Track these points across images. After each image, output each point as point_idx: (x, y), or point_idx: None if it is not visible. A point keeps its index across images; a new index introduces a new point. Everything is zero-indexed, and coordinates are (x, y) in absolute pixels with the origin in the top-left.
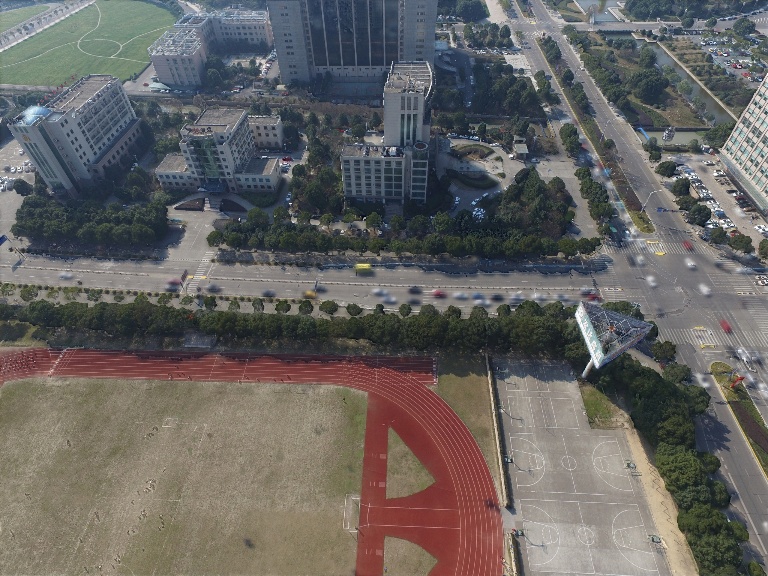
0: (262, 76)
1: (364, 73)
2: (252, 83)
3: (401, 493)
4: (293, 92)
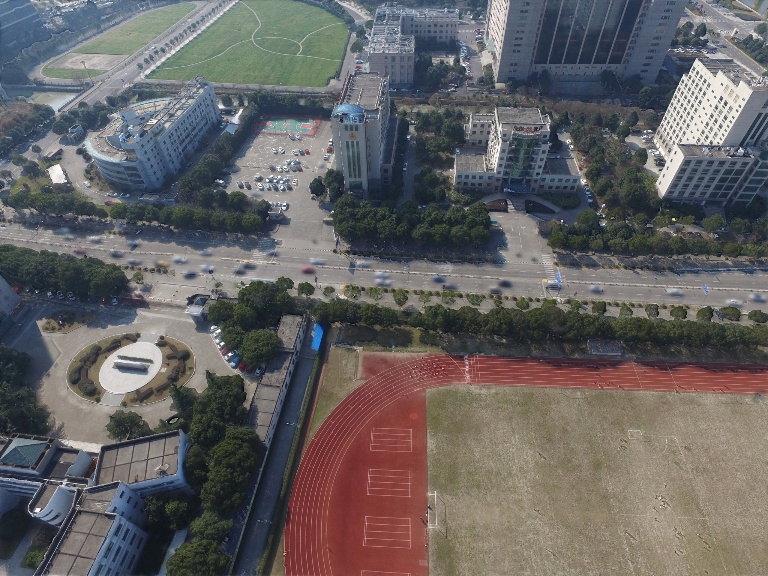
0: (469, 74)
1: (582, 72)
2: (462, 81)
3: None
4: (523, 91)
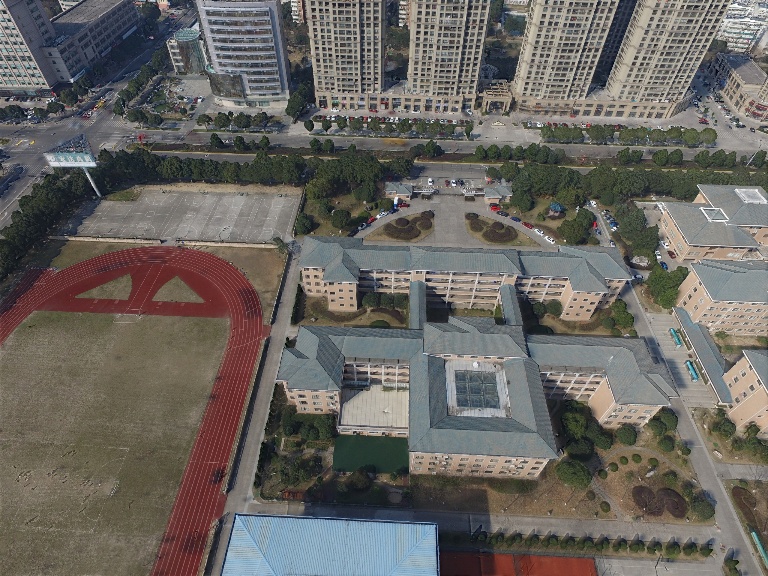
0: None
1: None
2: None
3: (128, 292)
4: None
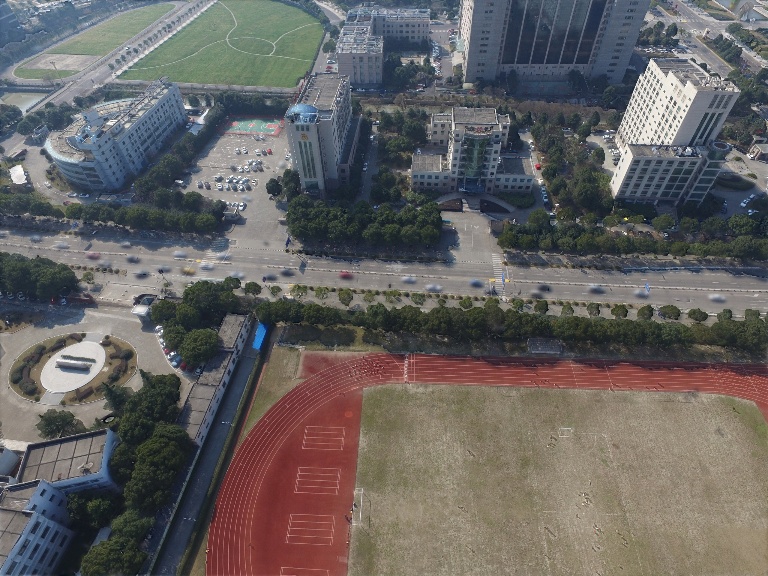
0: (439, 74)
1: (550, 71)
2: (431, 82)
3: None
4: (489, 91)
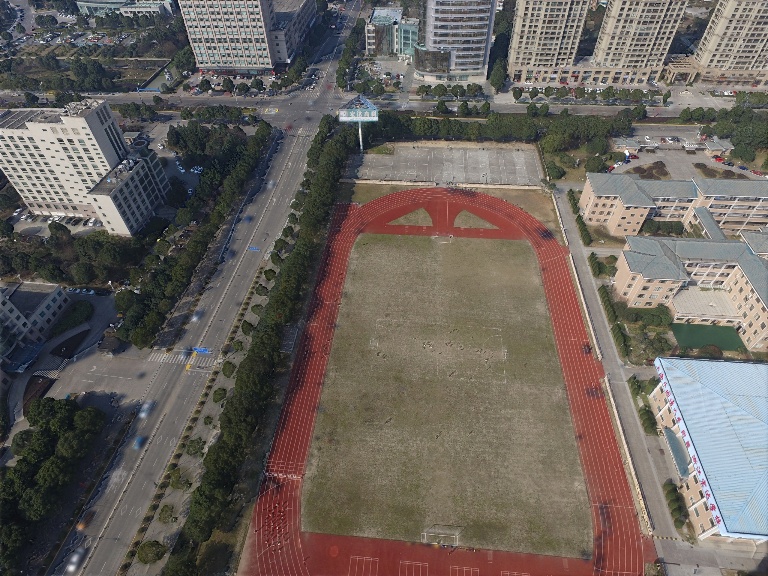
0: None
1: None
2: None
3: (430, 220)
4: None
